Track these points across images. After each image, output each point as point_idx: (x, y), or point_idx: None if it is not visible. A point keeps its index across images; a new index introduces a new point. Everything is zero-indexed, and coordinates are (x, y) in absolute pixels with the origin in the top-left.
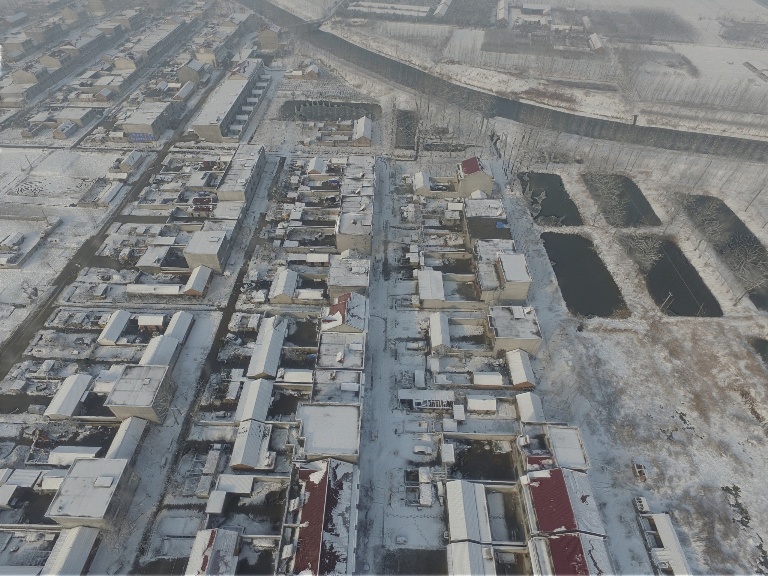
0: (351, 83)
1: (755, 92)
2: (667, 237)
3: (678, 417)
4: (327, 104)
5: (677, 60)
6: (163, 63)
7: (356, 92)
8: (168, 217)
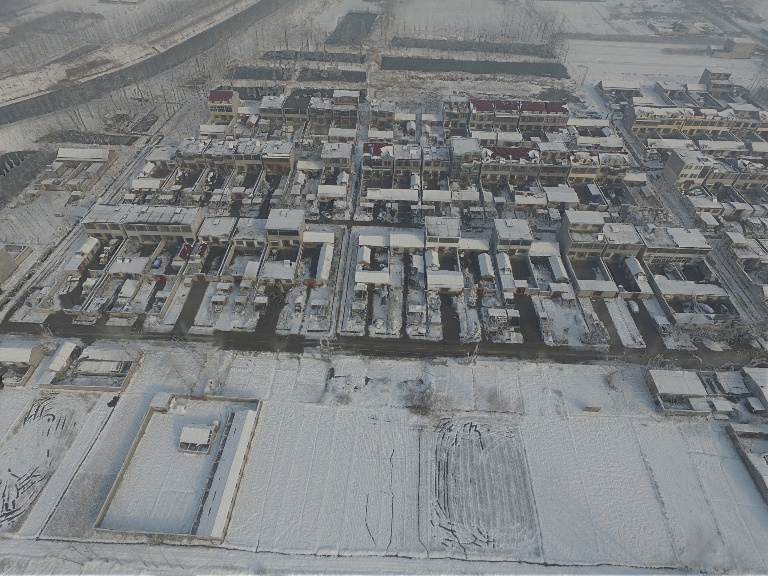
0: None
1: (167, 5)
2: (304, 69)
3: None
4: None
5: (69, 16)
6: None
7: None
8: (195, 286)
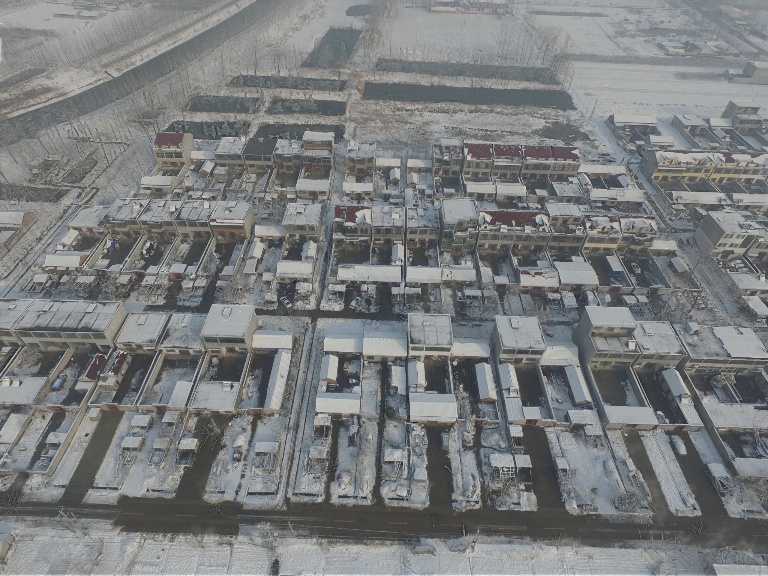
0: None
1: (126, 21)
2: (275, 99)
3: None
4: None
5: (16, 33)
6: None
7: None
8: (104, 419)
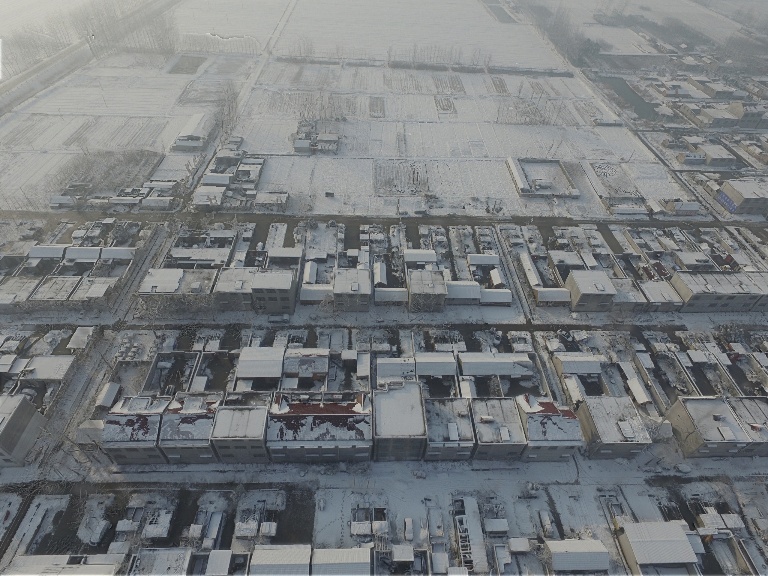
0: None
1: None
2: None
3: None
4: None
5: None
6: None
7: None
8: None
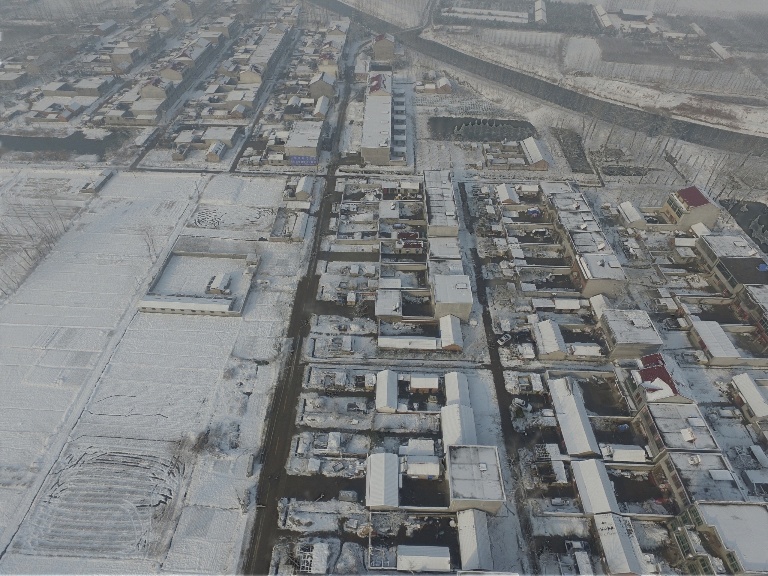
0: (489, 98)
1: None
2: None
3: None
4: (470, 121)
5: None
6: (280, 75)
7: (498, 108)
8: (373, 254)
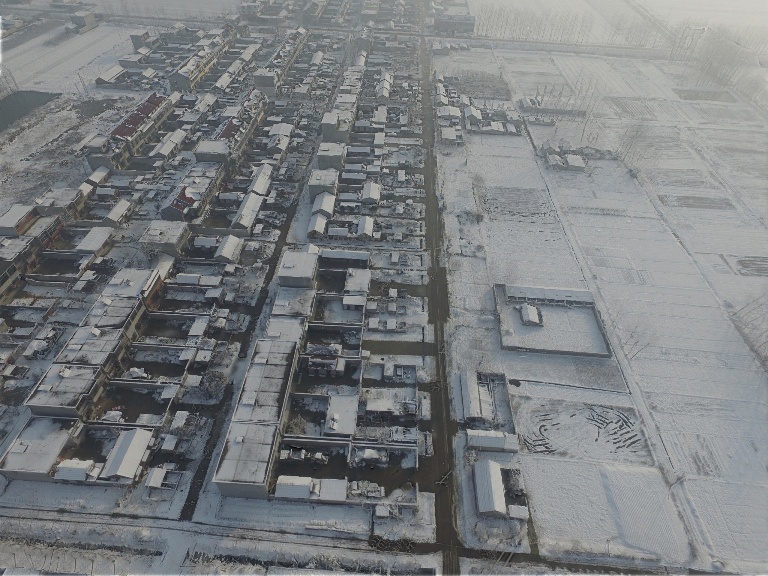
0: None
1: None
2: None
3: (8, 181)
4: None
5: None
6: None
7: None
8: None
